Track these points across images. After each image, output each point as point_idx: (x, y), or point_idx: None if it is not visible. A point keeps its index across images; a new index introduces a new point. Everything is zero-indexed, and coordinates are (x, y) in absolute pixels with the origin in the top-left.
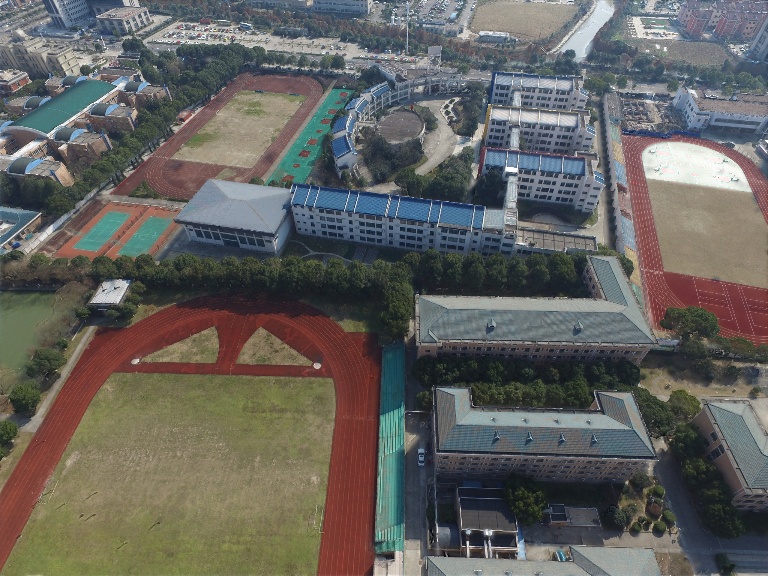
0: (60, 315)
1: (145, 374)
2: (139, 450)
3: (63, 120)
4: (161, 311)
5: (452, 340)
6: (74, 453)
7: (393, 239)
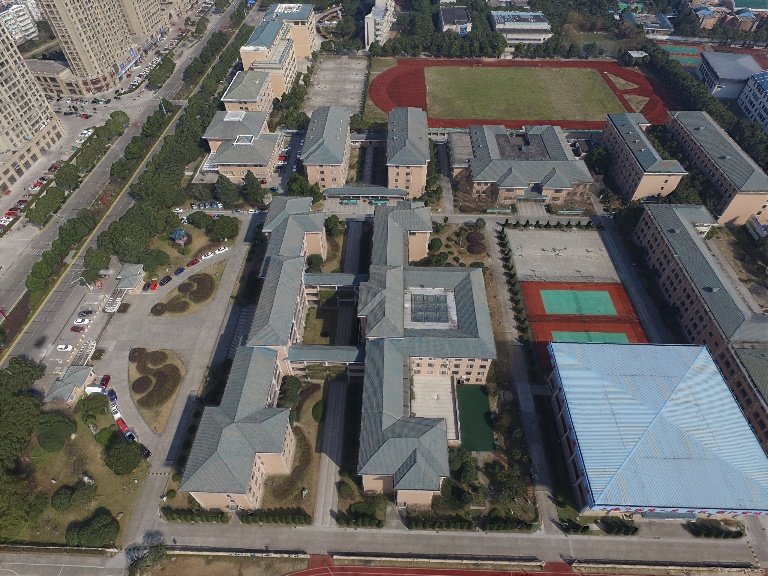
0: (616, 44)
1: (601, 75)
2: (567, 80)
3: (754, 7)
4: (638, 73)
5: (679, 121)
6: (558, 69)
7: (765, 128)
